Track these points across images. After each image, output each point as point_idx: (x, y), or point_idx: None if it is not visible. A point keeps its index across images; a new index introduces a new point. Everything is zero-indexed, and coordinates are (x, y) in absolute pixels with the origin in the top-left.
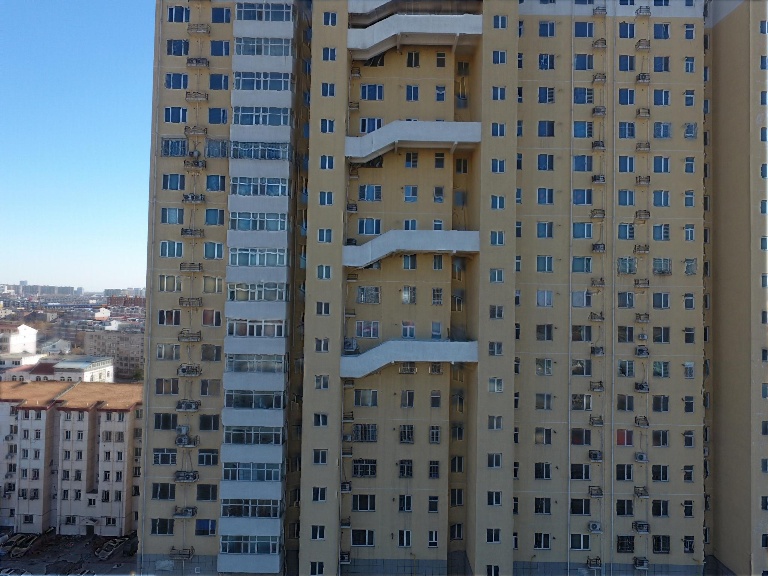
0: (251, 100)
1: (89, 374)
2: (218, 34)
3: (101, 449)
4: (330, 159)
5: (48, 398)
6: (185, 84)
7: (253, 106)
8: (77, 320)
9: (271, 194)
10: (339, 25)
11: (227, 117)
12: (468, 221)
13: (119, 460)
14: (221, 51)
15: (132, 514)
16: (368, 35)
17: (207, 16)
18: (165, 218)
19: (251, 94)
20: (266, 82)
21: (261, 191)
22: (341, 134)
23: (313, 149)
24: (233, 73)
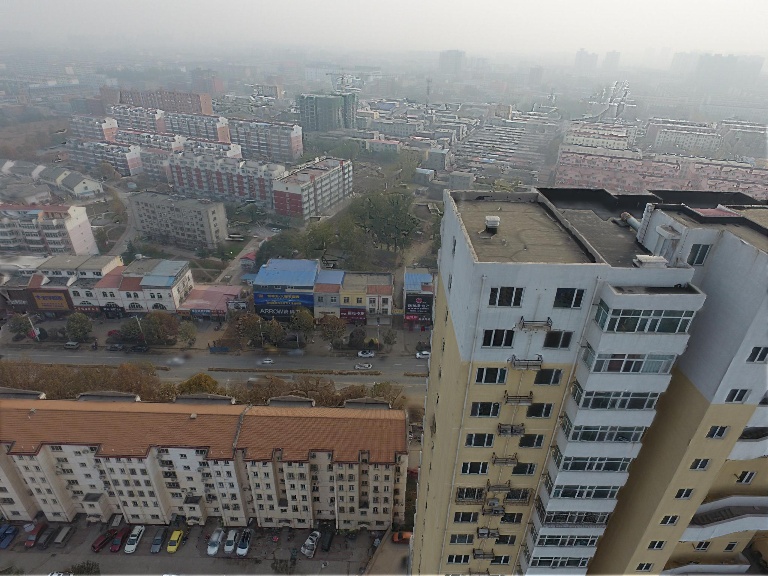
0: (579, 481)
1: (176, 288)
2: (541, 397)
3: (286, 483)
4: (661, 542)
5: (227, 444)
6: (489, 442)
7: (579, 484)
8: (90, 142)
9: (578, 544)
10: (727, 440)
11: (534, 470)
12: (763, 540)
13: (303, 489)
14: (540, 412)
15: (314, 511)
16: (759, 448)
17: (531, 380)
18: (454, 540)
19: (580, 476)
20: (601, 464)
21: (568, 543)
22: (682, 527)
23: (646, 537)
24: (562, 455)
